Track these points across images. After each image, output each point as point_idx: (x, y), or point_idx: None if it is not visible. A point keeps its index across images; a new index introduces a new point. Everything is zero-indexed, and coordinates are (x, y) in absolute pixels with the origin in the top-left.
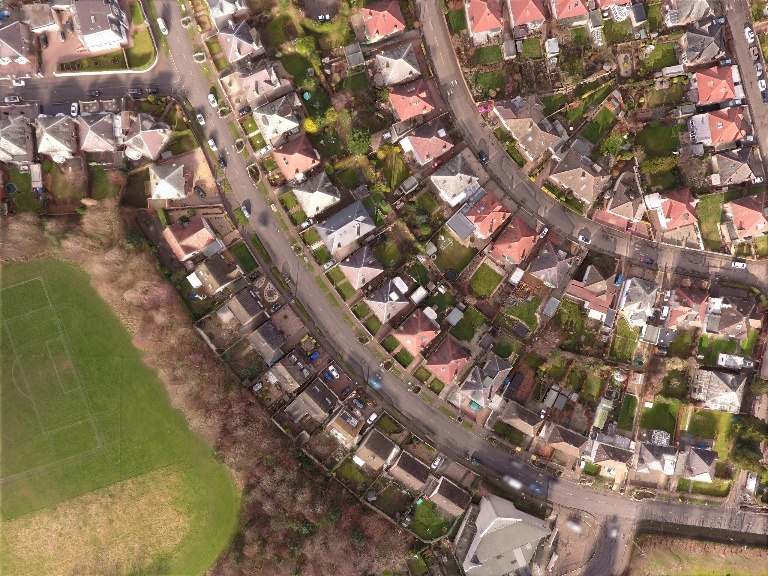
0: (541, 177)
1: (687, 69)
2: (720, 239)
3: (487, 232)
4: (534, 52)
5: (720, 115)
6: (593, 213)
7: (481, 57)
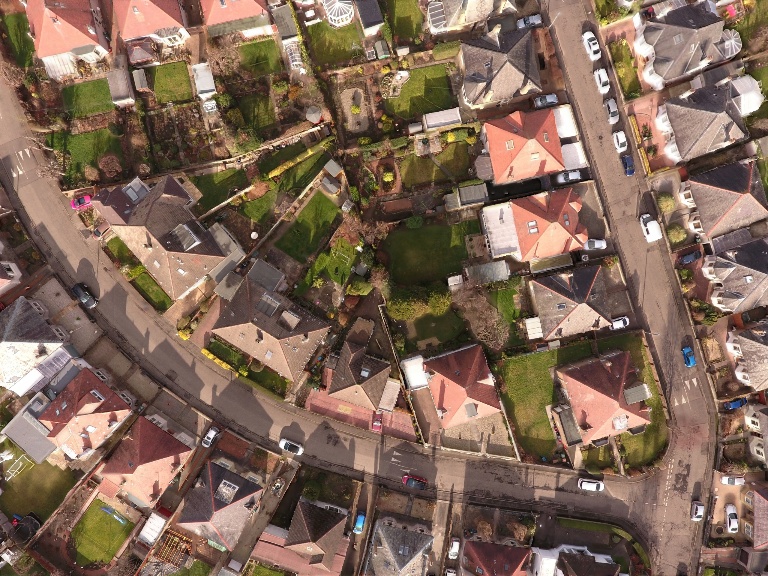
0: (203, 329)
1: (474, 114)
2: (553, 436)
3: (81, 450)
4: (177, 90)
5: (533, 206)
6: (307, 395)
7: (74, 102)
